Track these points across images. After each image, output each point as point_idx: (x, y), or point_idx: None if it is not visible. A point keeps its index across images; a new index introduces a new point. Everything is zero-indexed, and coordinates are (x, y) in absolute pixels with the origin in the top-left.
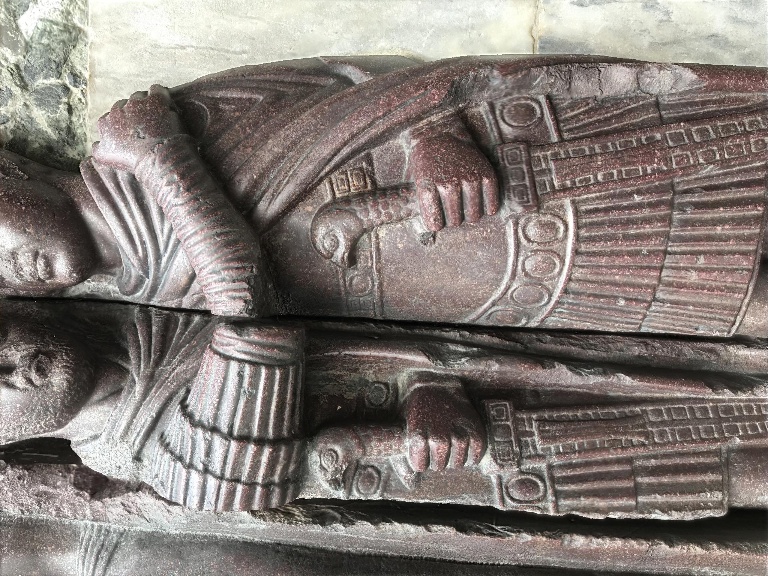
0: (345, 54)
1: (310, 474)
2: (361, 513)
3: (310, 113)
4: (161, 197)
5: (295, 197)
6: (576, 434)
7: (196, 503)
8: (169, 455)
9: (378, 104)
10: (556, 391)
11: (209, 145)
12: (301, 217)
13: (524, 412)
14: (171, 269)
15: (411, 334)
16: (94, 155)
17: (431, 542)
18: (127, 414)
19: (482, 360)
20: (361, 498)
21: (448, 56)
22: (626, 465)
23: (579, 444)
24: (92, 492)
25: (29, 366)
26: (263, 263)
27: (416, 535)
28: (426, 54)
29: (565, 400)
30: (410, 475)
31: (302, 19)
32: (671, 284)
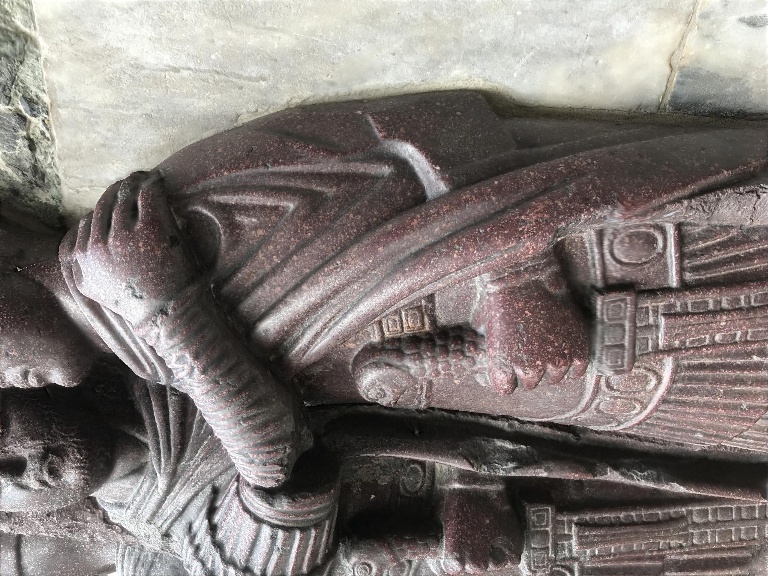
0: (404, 85)
1: (342, 564)
2: None
3: (358, 255)
4: None
5: (335, 348)
6: (615, 540)
7: None
8: (200, 565)
9: (451, 258)
10: (602, 482)
11: (225, 280)
12: (341, 353)
13: (565, 515)
14: None
15: (455, 420)
16: (78, 289)
17: None
18: (152, 506)
19: (530, 469)
20: None
21: (547, 91)
22: (658, 561)
23: (616, 547)
24: None
25: (40, 469)
26: (296, 414)
27: None
28: (516, 88)
29: (609, 495)
30: (442, 574)
31: (345, 33)
32: (762, 429)
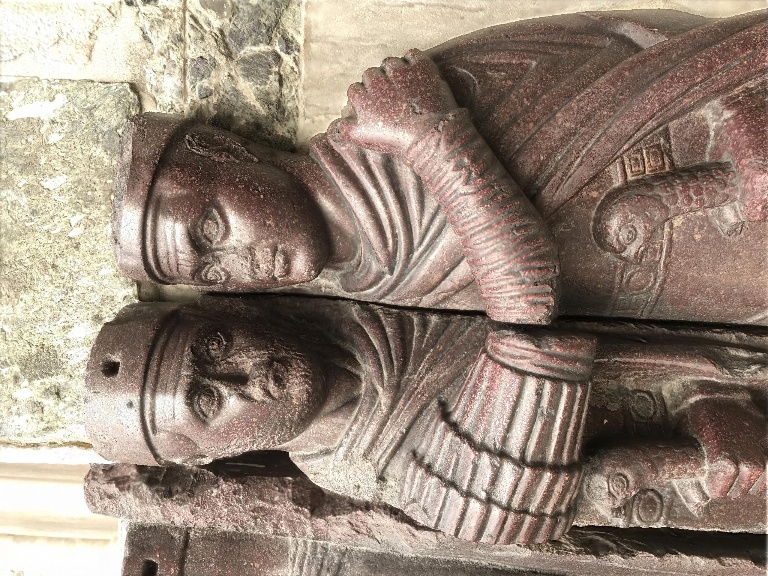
0: (597, 9)
1: (584, 499)
2: (637, 542)
3: (607, 80)
4: (443, 184)
5: (587, 181)
6: None
7: (473, 535)
8: (437, 479)
9: (696, 68)
10: None
11: (482, 120)
12: (584, 204)
13: None
14: (424, 265)
15: (677, 336)
16: (350, 134)
17: (718, 575)
18: (373, 429)
19: None
20: (641, 526)
21: (718, 9)
22: None
23: None
24: (311, 508)
25: (266, 376)
26: None
27: (705, 569)
28: (692, 7)
29: None
30: (704, 502)
31: None
32: None
